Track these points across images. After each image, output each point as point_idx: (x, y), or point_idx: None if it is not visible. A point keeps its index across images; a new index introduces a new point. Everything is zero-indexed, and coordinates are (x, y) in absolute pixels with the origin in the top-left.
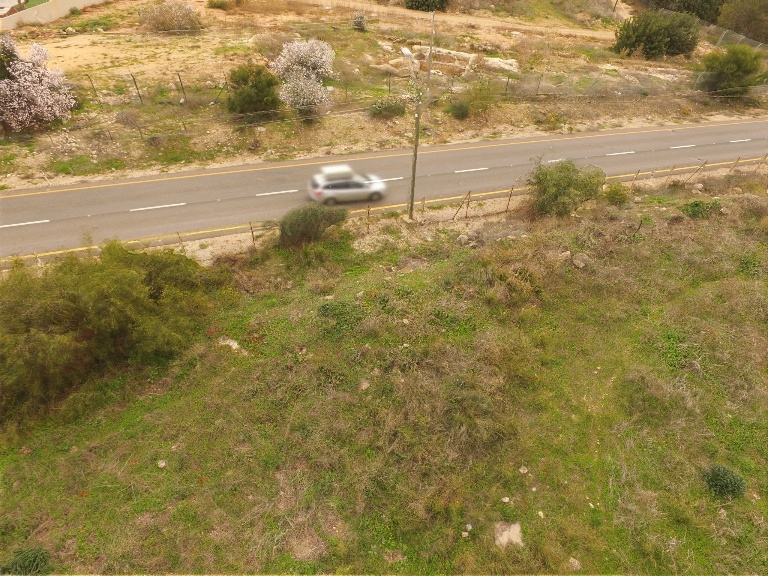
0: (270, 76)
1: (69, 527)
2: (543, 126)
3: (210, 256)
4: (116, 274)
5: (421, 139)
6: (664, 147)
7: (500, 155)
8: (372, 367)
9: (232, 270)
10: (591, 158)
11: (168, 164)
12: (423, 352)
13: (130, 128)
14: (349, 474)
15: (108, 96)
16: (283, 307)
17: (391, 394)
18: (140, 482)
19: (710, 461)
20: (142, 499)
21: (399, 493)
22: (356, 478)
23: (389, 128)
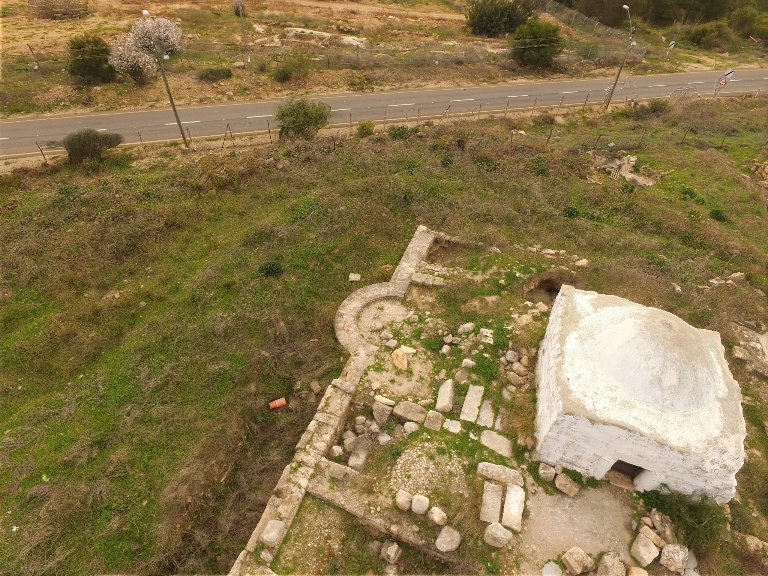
0: None
1: None
2: (354, 87)
3: (11, 169)
4: None
5: (239, 97)
6: (444, 100)
7: None
8: None
9: (22, 177)
10: (373, 108)
11: (10, 114)
12: (120, 212)
13: None
14: None
15: None
16: None
17: None
18: None
19: None
20: None
21: None
22: None
23: (214, 88)
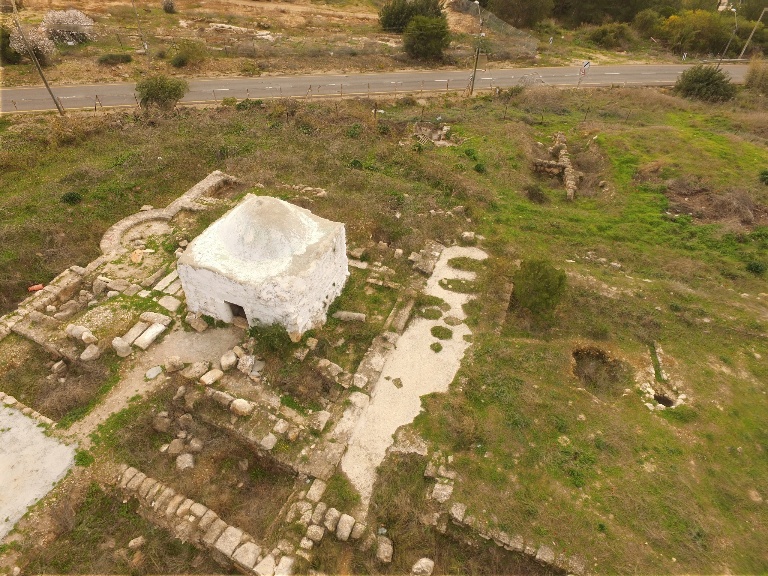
0: None
1: None
2: (246, 73)
3: None
4: None
5: None
6: (321, 84)
7: None
8: None
9: None
10: None
11: None
12: None
13: None
14: None
15: None
16: None
17: None
18: None
19: None
20: None
21: None
22: None
23: (112, 71)
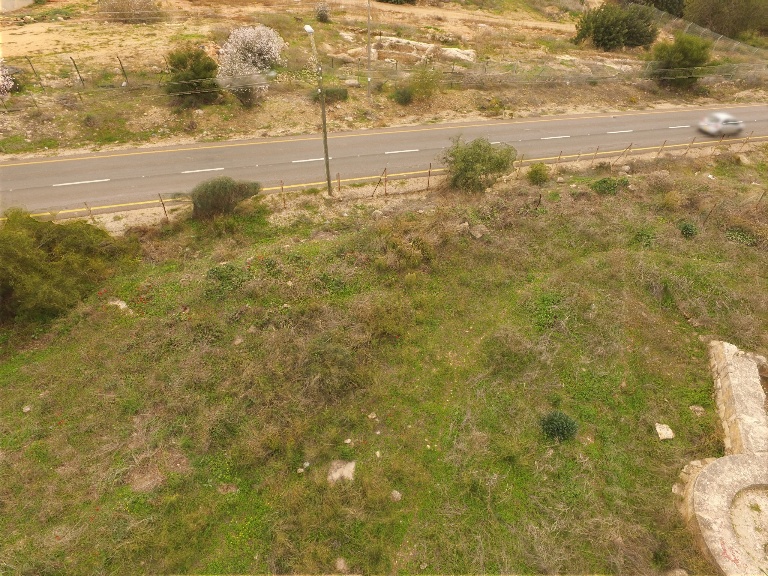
0: (209, 60)
1: None
2: (486, 112)
3: (123, 227)
4: (2, 235)
5: (361, 123)
6: (601, 132)
7: (434, 138)
8: (250, 325)
9: (140, 240)
10: (525, 141)
11: (101, 144)
12: (301, 311)
13: (23, 97)
14: (200, 417)
15: (52, 80)
16: (178, 272)
17: (259, 348)
18: (1, 424)
19: (552, 408)
20: (0, 439)
21: (245, 434)
22: (204, 420)
23: (330, 112)
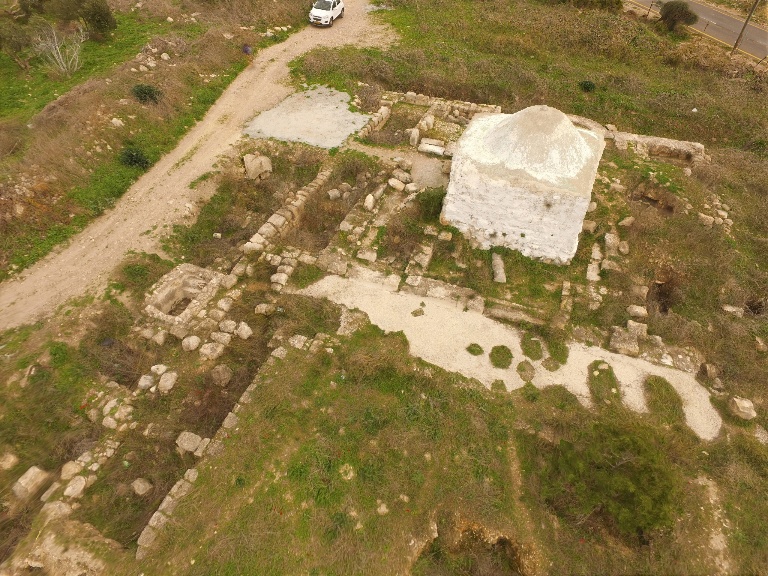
0: None
1: (501, 3)
2: None
3: None
4: None
5: None
6: None
7: None
8: None
9: None
10: None
11: None
12: None
13: None
14: None
15: None
16: None
17: None
18: None
19: None
20: None
21: None
22: None
23: None
